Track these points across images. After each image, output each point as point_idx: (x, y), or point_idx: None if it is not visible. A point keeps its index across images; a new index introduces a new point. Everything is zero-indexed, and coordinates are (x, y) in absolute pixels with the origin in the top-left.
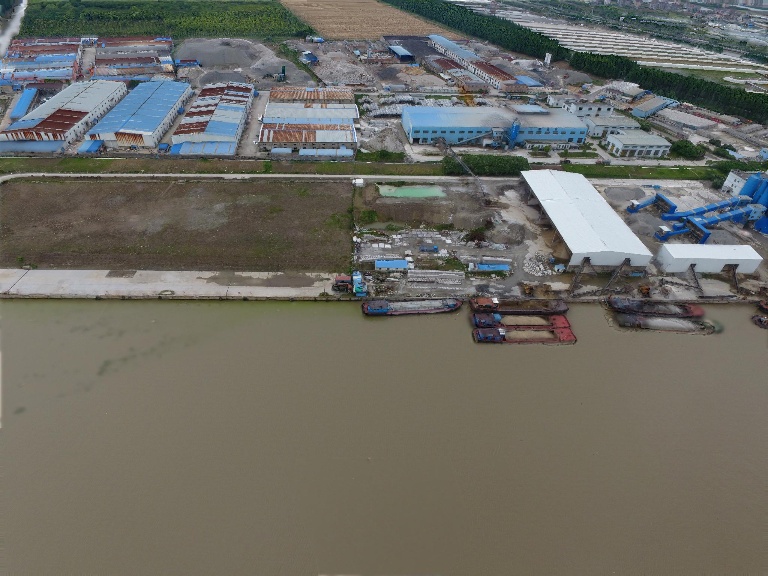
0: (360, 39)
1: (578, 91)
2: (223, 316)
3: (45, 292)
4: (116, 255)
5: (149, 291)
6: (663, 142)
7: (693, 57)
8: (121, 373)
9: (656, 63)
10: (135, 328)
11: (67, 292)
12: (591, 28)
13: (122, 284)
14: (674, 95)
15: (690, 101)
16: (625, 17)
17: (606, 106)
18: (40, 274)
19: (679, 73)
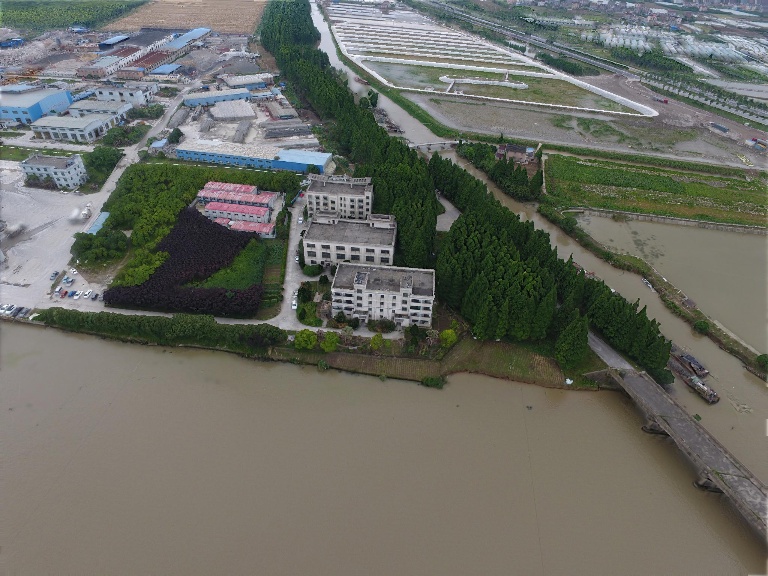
0: (134, 31)
1: (202, 81)
2: None
3: None
4: None
5: None
6: (80, 126)
7: (477, 56)
8: None
9: (398, 60)
10: None
11: None
12: (445, 27)
13: None
14: (290, 88)
15: (303, 95)
16: (517, 17)
17: (128, 91)
18: None
19: (401, 70)
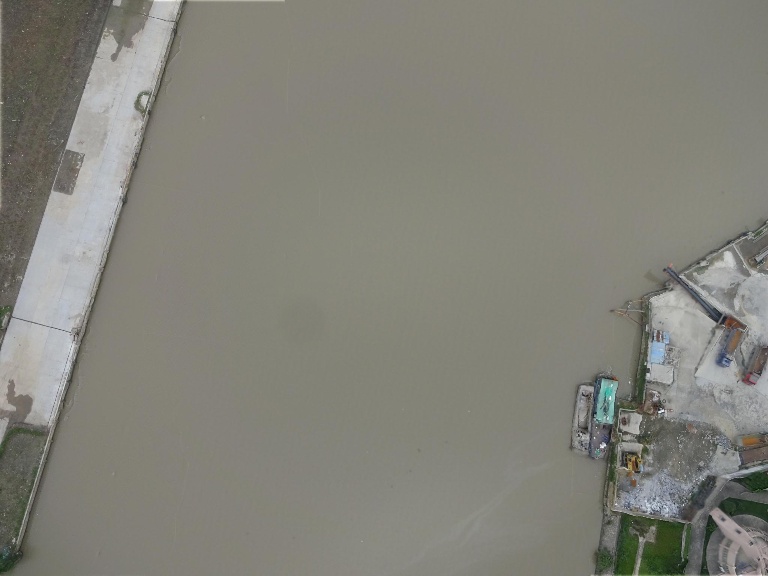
0: None
1: None
2: (217, 29)
3: (90, 275)
4: (6, 186)
5: (130, 127)
6: None
7: None
8: (295, 149)
9: None
10: (212, 140)
11: (99, 243)
12: None
13: (100, 167)
14: None
15: None
16: None
17: None
18: (32, 296)
19: None
